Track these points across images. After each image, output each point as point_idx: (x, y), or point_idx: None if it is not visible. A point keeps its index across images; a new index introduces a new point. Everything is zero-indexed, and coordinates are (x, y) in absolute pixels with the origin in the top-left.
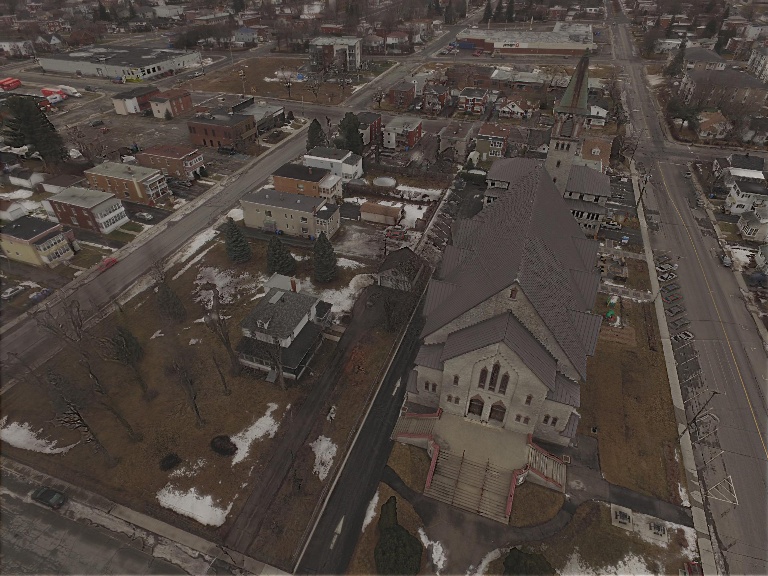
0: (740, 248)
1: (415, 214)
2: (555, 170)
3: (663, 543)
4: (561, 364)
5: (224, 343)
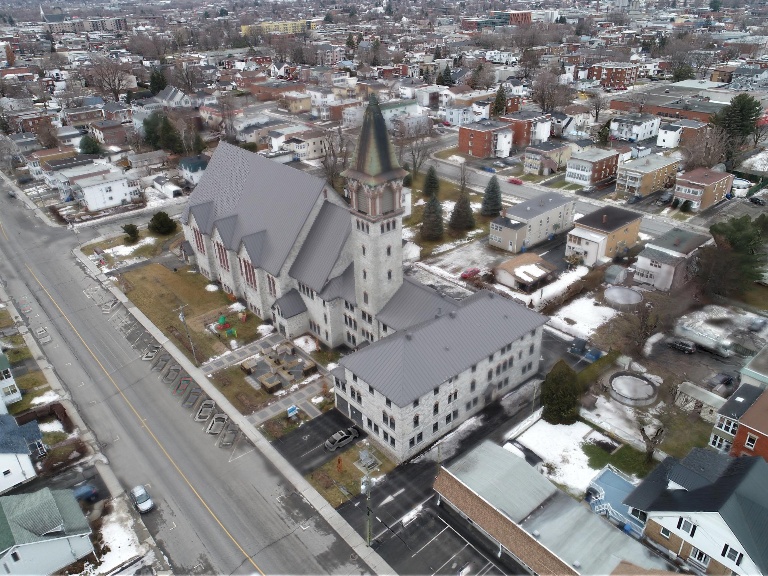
0: (125, 569)
1: None
2: None
3: None
4: None
5: None
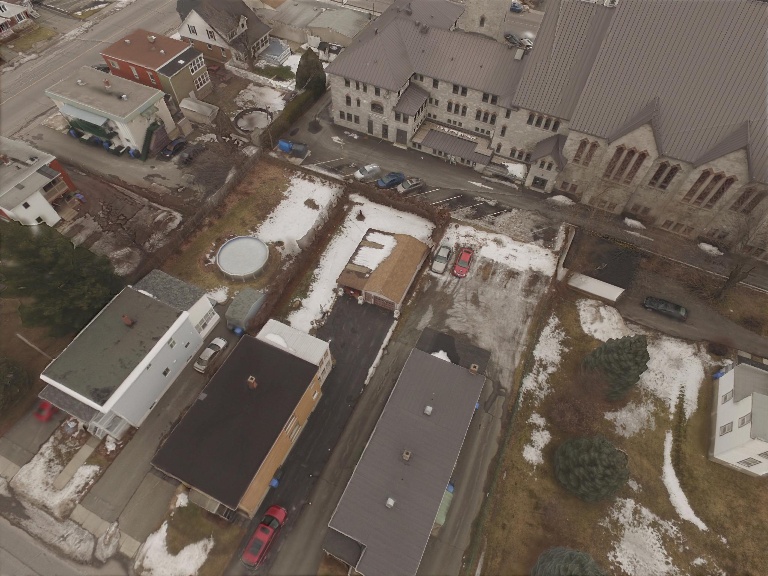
0: None
1: (382, 227)
2: (508, 1)
3: None
4: None
5: None
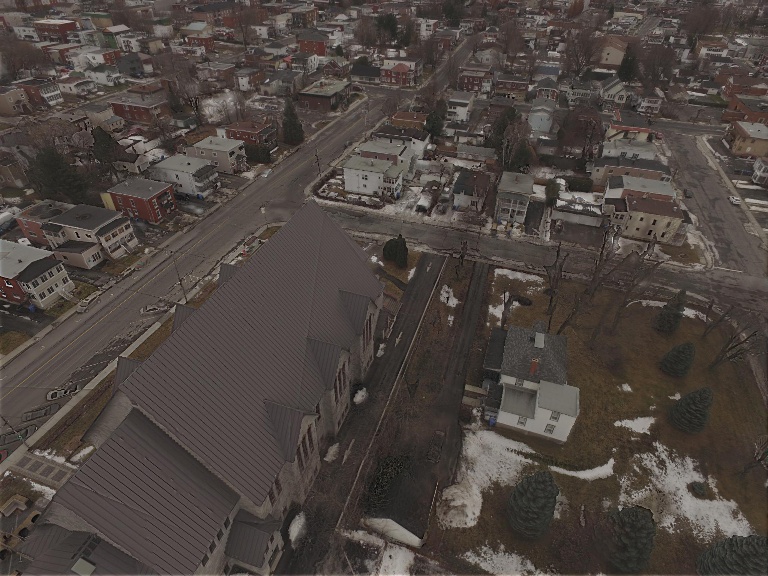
0: None
1: None
2: None
3: None
4: None
5: None
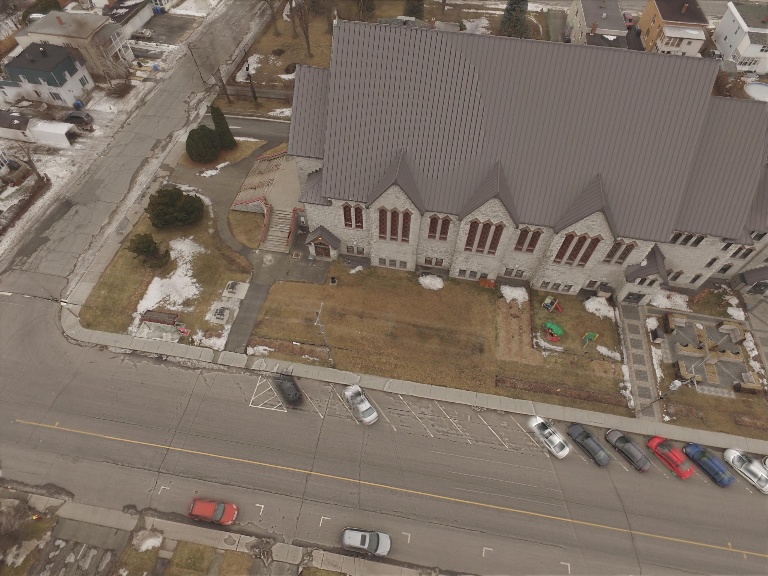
0: None
1: None
2: None
3: (209, 317)
4: None
5: None
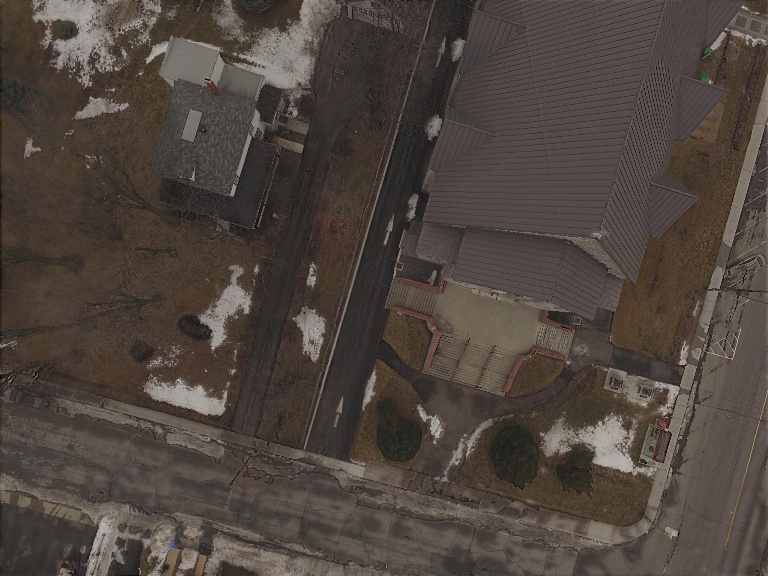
0: None
1: None
2: None
3: (645, 403)
4: (613, 270)
5: (140, 208)
